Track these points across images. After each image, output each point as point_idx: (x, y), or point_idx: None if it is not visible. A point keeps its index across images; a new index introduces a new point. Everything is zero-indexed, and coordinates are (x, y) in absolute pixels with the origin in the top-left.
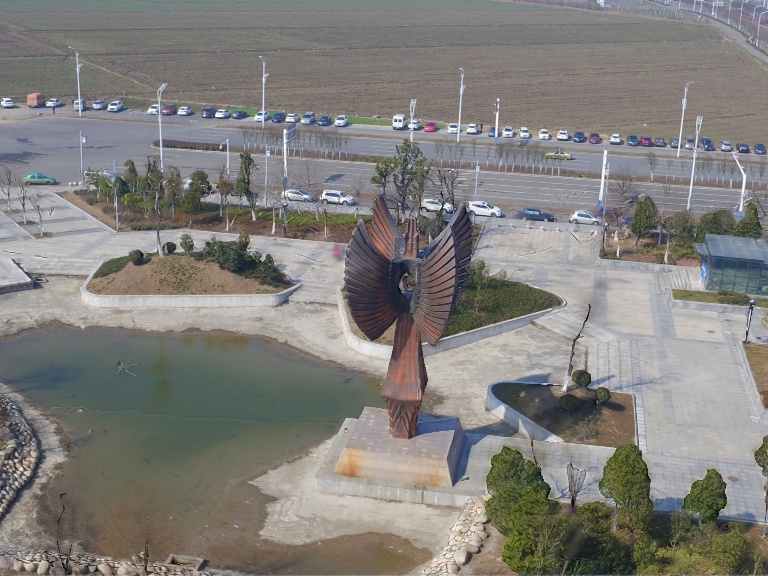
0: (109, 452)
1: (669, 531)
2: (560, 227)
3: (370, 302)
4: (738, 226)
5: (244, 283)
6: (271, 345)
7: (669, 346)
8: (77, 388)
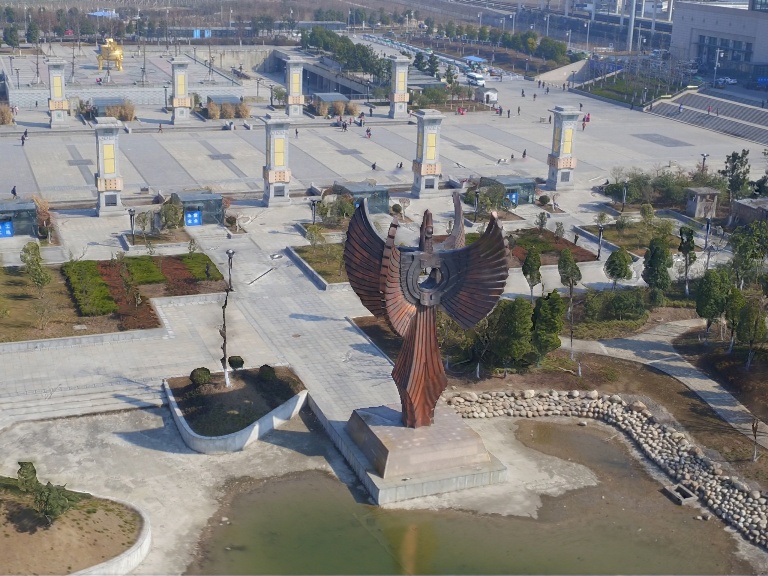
0: None
1: None
2: None
3: None
4: None
5: None
6: None
7: None
8: None
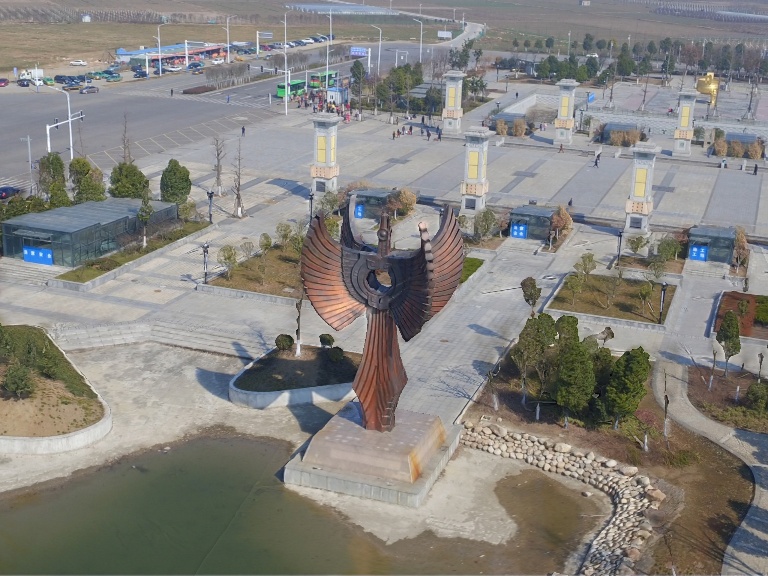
0: None
1: None
2: None
3: None
4: (16, 206)
5: None
6: None
7: (182, 310)
8: None
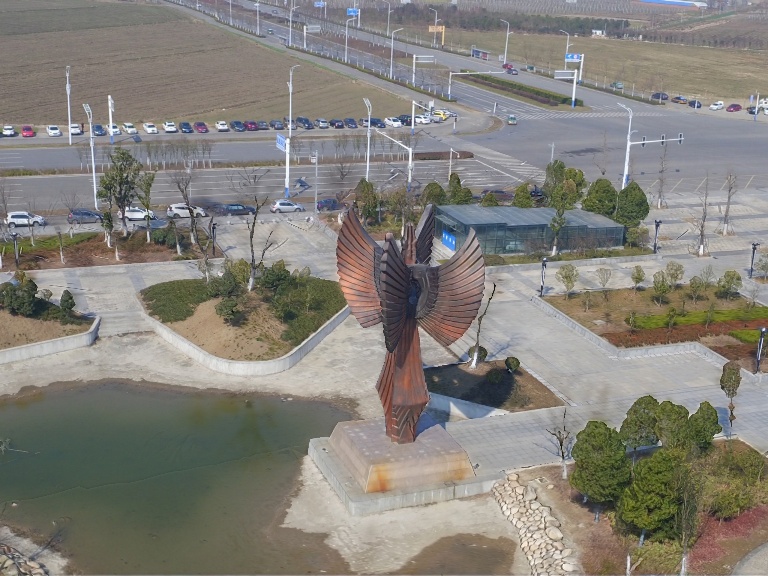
0: (103, 539)
1: (688, 462)
2: (272, 218)
3: (398, 314)
4: (460, 195)
5: (45, 327)
6: (132, 386)
7: (486, 311)
8: None
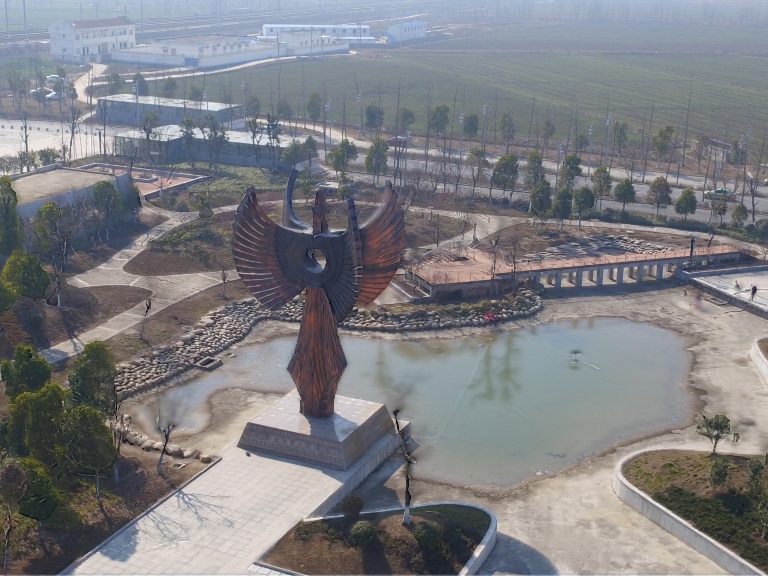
0: (399, 352)
1: None
2: None
3: None
4: None
5: None
6: (662, 425)
7: None
8: (532, 346)
